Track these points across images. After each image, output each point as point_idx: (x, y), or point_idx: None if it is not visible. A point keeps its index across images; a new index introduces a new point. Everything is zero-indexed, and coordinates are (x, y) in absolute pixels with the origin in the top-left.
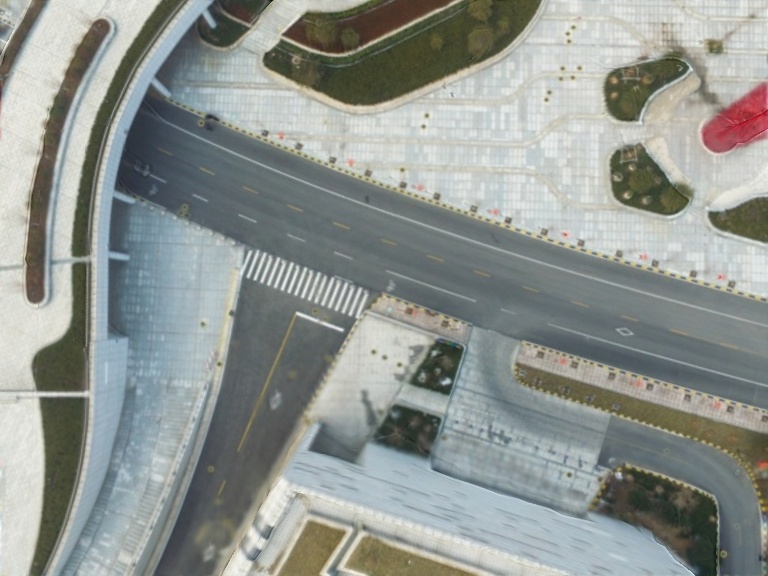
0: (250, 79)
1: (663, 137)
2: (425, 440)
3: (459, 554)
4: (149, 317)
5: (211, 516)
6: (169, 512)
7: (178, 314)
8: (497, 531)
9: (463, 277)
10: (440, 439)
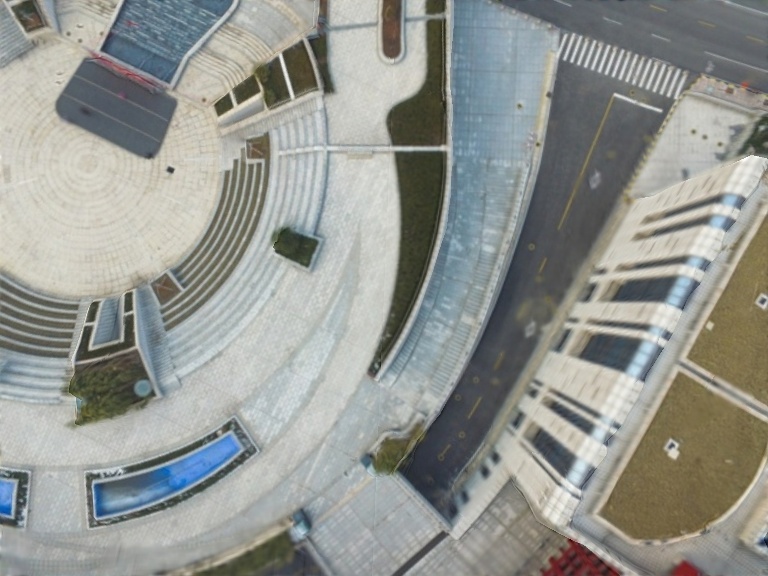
0: None
1: None
2: None
3: None
4: (466, 99)
5: (532, 293)
6: None
7: (494, 96)
8: None
9: None
10: None
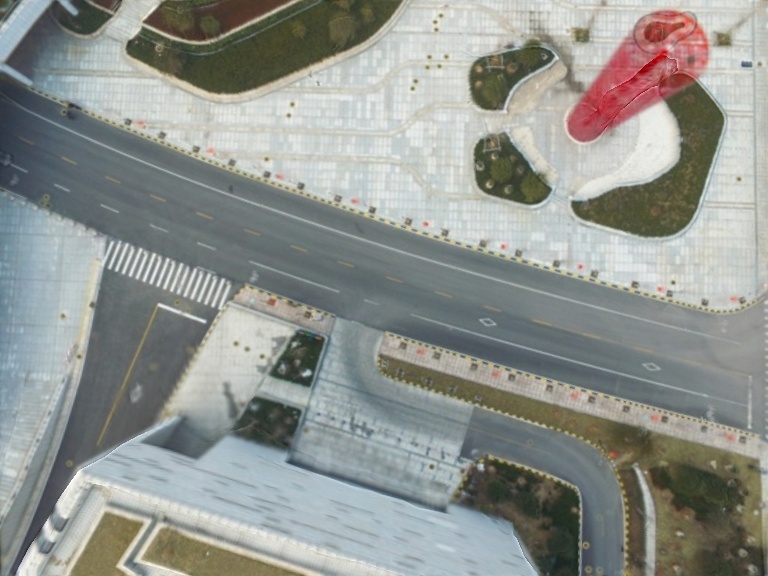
0: (114, 67)
1: (528, 126)
2: (284, 432)
3: (261, 545)
4: (8, 309)
5: None
6: (25, 507)
7: (38, 306)
8: (310, 522)
9: (327, 268)
10: (301, 431)
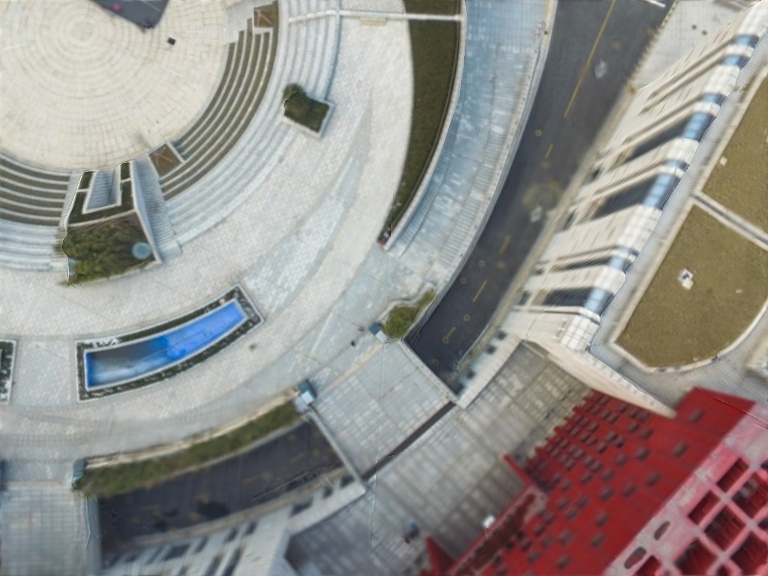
0: None
1: None
2: None
3: None
4: None
5: (538, 179)
6: None
7: None
8: None
9: None
10: None
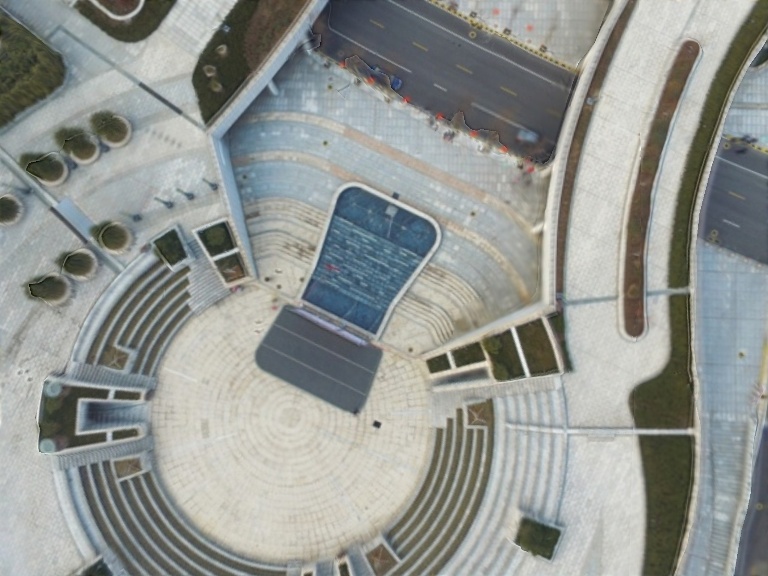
0: None
1: None
2: None
3: None
4: None
5: (761, 556)
6: None
7: (714, 344)
8: None
9: None
10: None
